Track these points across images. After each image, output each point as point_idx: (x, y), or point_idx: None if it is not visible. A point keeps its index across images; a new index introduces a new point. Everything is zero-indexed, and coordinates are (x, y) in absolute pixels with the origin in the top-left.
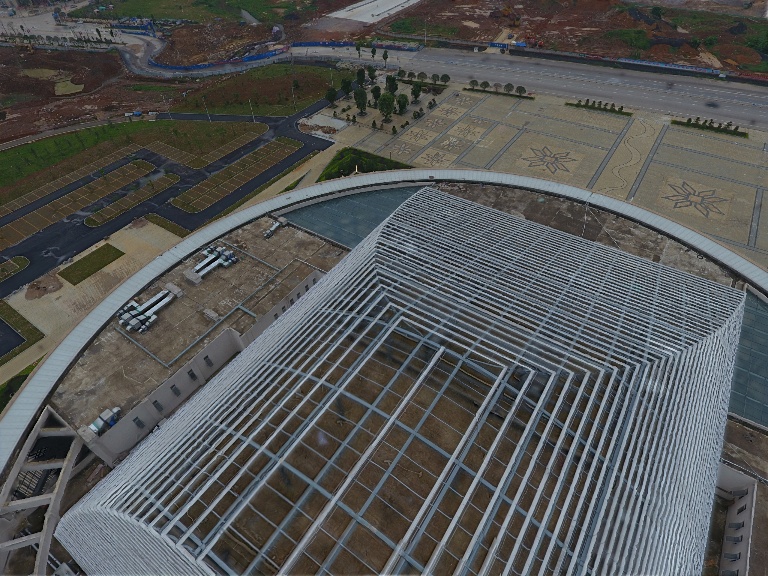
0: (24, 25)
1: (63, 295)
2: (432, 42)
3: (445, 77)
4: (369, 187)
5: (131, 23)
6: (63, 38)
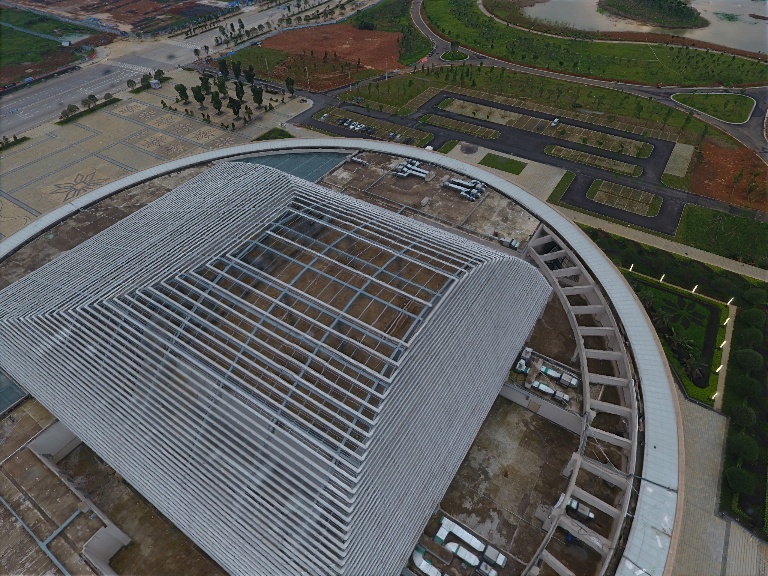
0: None
1: None
2: None
3: None
4: None
5: None
6: None
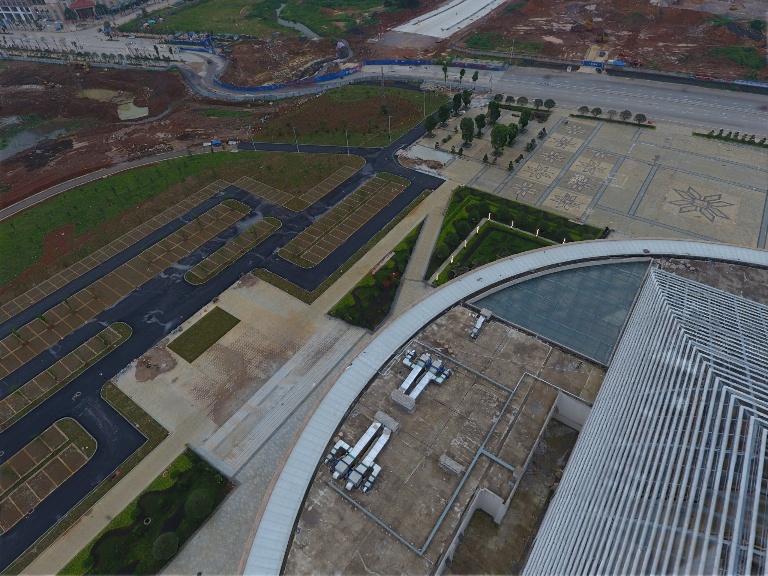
0: (77, 41)
1: (180, 376)
2: (517, 60)
3: (550, 102)
4: (573, 264)
5: (186, 38)
6: (120, 55)
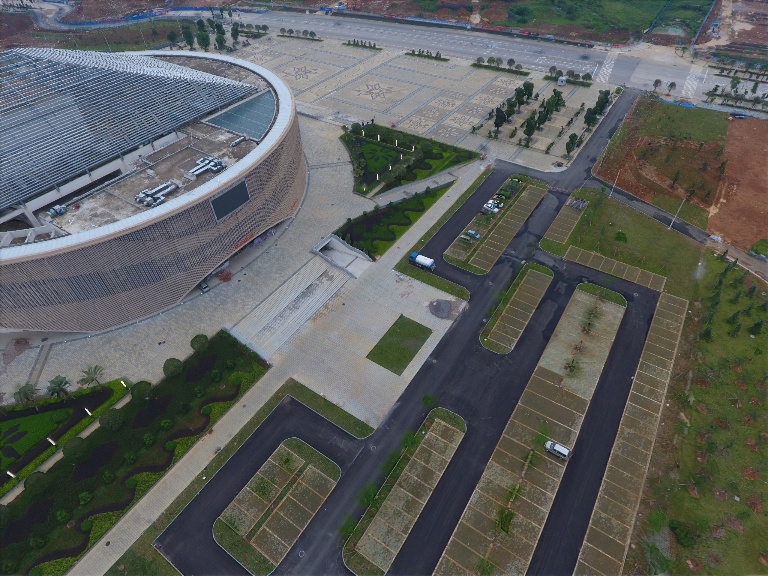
0: None
1: None
2: (279, 7)
3: (264, 27)
4: None
5: None
6: None
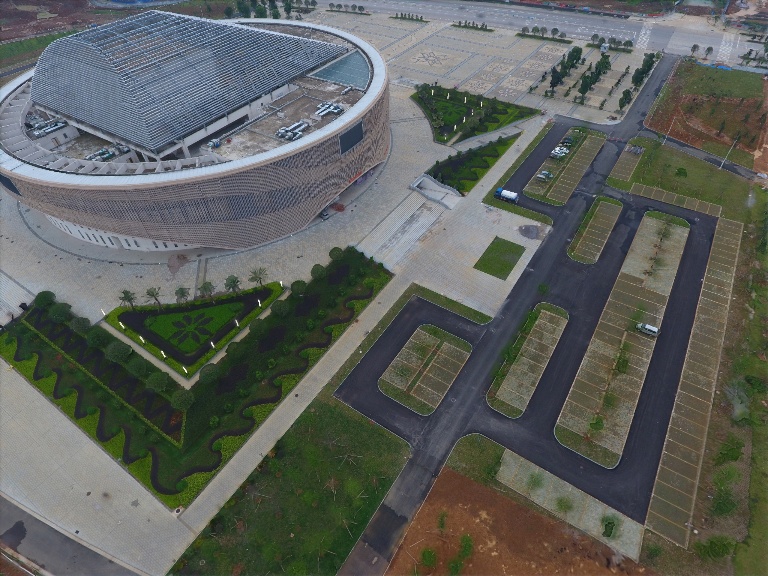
0: None
1: None
2: None
3: (313, 2)
4: None
5: None
6: None
